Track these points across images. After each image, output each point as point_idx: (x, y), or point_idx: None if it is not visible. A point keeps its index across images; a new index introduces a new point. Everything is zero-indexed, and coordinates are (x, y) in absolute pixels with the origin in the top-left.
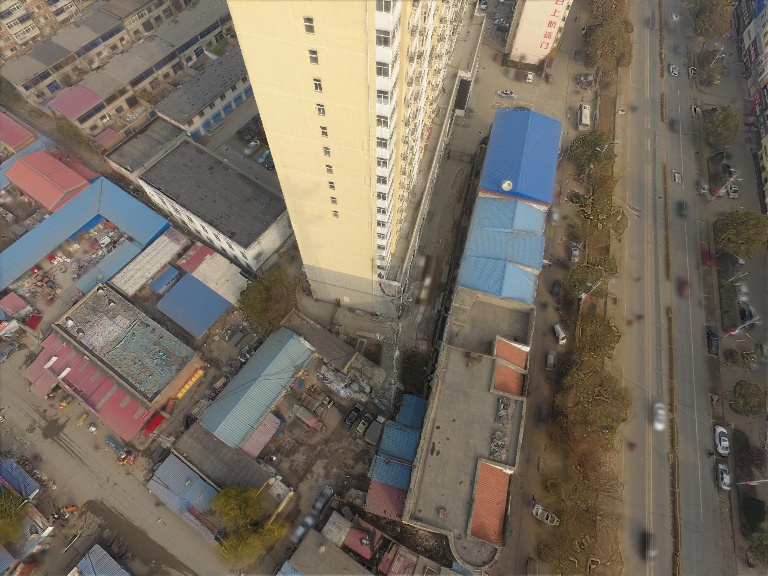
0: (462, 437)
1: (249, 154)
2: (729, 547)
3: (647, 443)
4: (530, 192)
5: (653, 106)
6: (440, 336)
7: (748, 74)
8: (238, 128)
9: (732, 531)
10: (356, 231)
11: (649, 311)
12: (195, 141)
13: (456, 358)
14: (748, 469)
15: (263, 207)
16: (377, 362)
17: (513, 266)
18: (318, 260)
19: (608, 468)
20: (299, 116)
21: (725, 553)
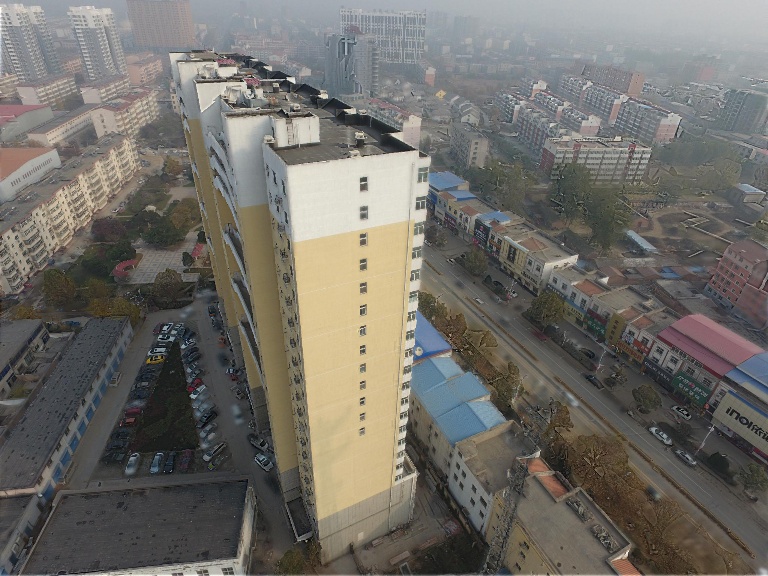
0: (580, 556)
1: (133, 472)
2: (736, 500)
3: (637, 472)
4: (434, 348)
5: (427, 269)
6: (458, 506)
7: (455, 232)
8: (98, 455)
9: (726, 487)
10: (380, 439)
11: (549, 386)
12: (48, 500)
13: (511, 497)
14: (688, 442)
15: (218, 503)
16: (433, 574)
17: (472, 403)
18: (336, 504)
19: (655, 499)
20: (342, 346)
21: (739, 506)
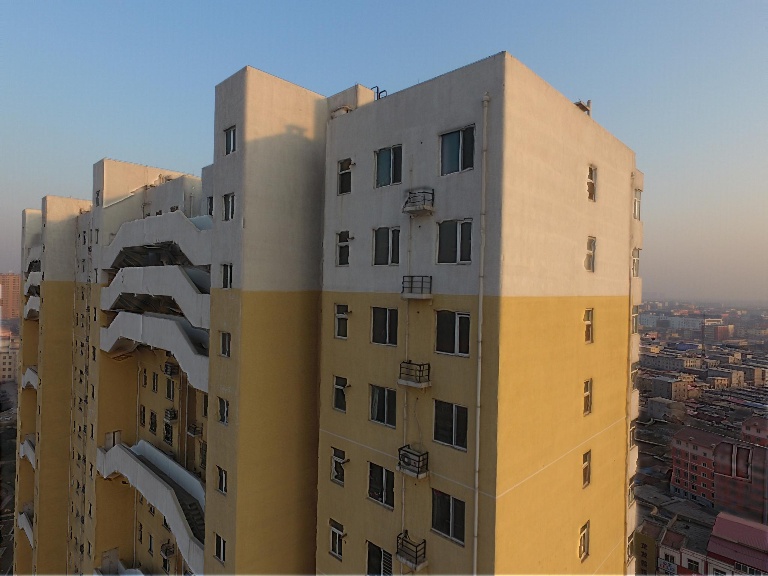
0: None
1: None
2: None
3: None
4: None
5: None
6: None
7: None
8: None
9: None
10: None
11: None
12: None
13: None
14: None
15: None
16: None
17: None
18: None
19: None
20: None
21: None
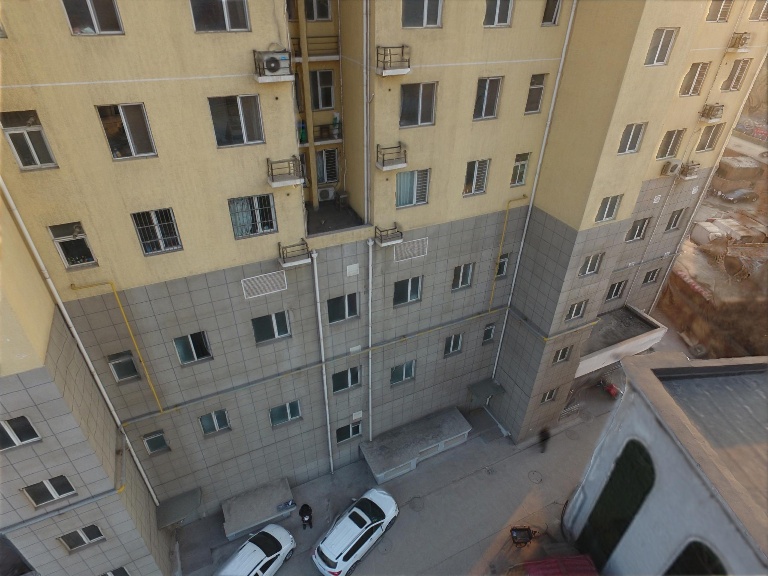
0: None
1: None
2: None
3: None
4: None
5: None
6: None
7: None
8: None
9: None
10: None
11: None
12: None
13: None
14: None
15: None
16: None
17: None
18: None
19: None
20: None
21: None
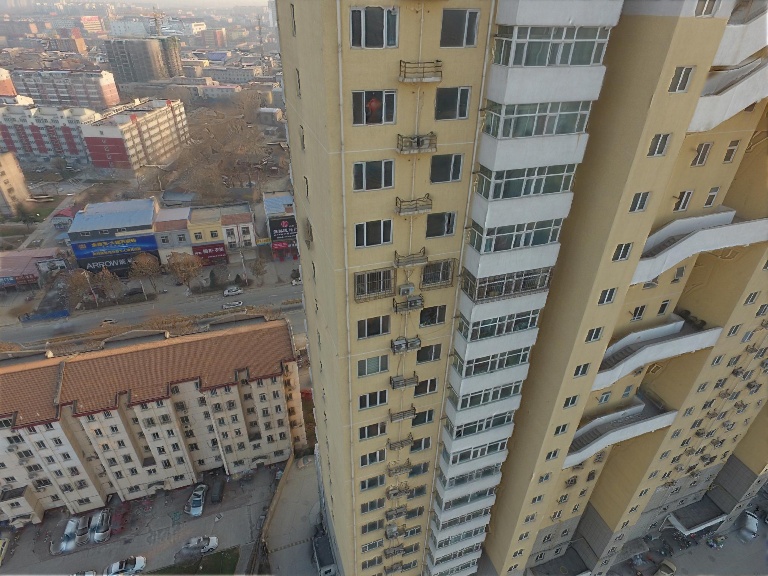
0: None
1: None
2: None
3: None
4: None
5: None
6: None
7: (218, 264)
8: None
9: None
10: None
11: None
12: None
13: None
14: None
15: None
16: None
17: None
18: None
19: None
20: None
21: None
